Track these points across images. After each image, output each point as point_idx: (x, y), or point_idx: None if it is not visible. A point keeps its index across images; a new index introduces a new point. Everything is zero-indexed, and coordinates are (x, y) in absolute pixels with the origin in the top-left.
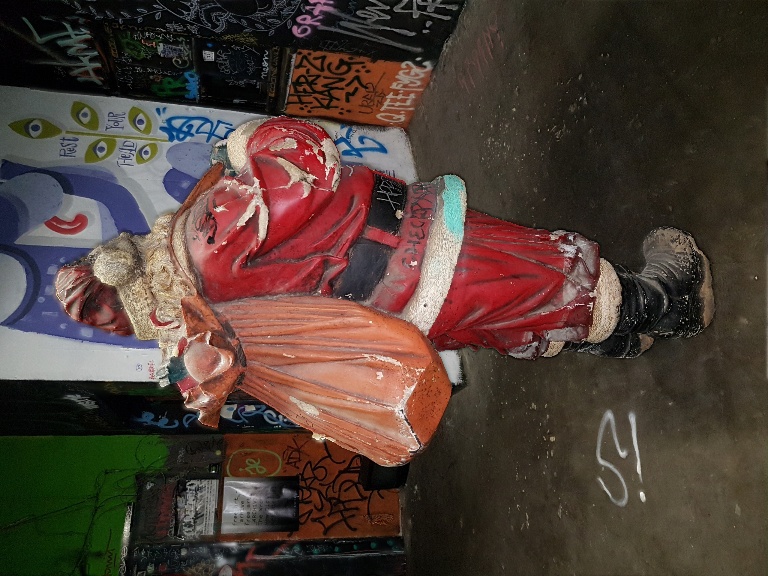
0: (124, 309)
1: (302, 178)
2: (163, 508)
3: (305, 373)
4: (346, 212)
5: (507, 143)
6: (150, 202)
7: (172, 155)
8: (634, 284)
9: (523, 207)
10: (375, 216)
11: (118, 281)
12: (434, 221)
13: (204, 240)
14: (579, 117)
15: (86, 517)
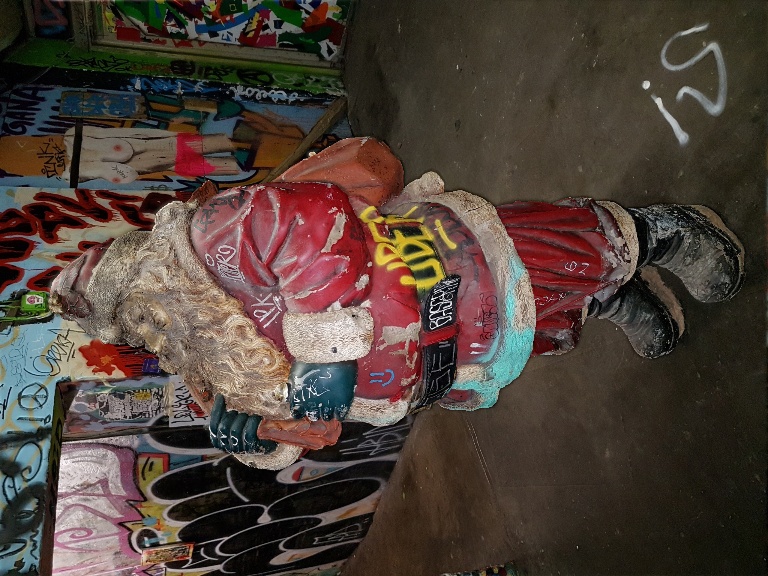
0: None
1: None
2: None
3: None
4: None
5: None
6: None
7: None
8: None
9: None
10: None
11: None
12: None
13: None
14: None
15: None
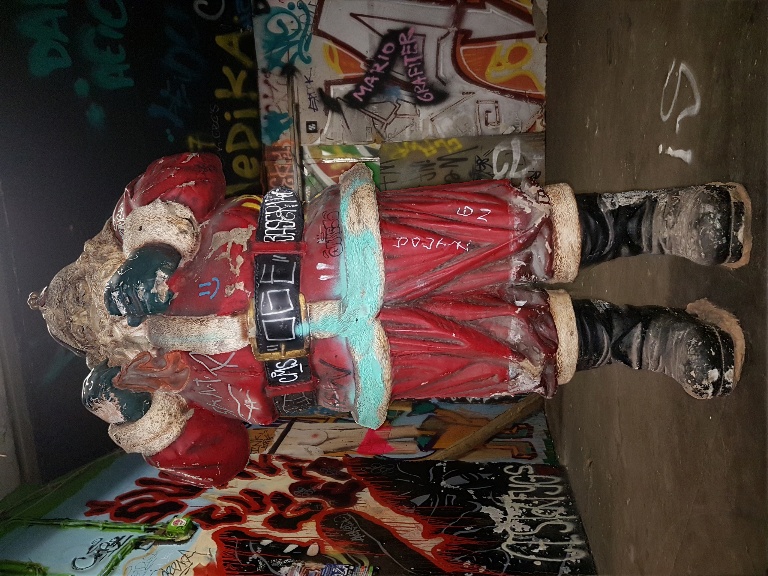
0: None
1: None
2: None
3: None
4: None
5: None
6: None
7: None
8: None
9: None
10: None
11: None
12: None
13: None
14: None
15: None
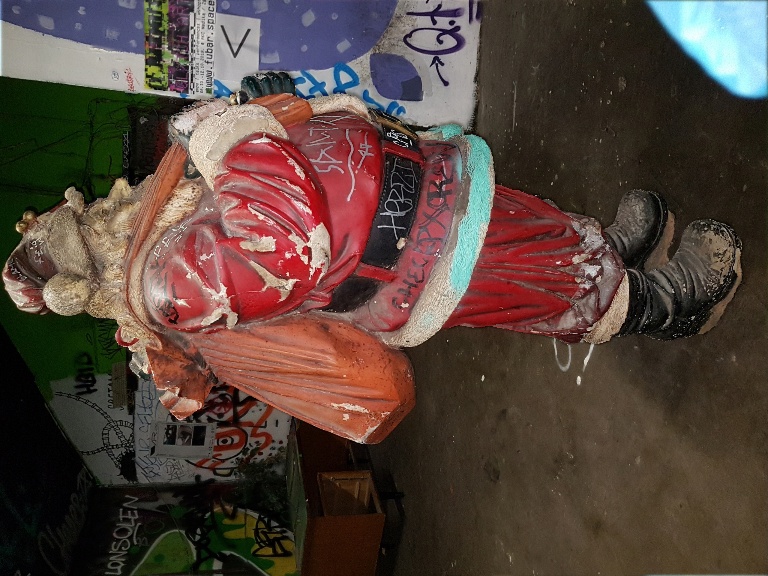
0: None
1: (279, 285)
2: (159, 143)
3: (275, 398)
4: (336, 257)
5: None
6: None
7: None
8: (644, 303)
9: (601, 7)
10: (371, 251)
11: None
12: (440, 262)
13: (165, 318)
14: None
15: (83, 141)
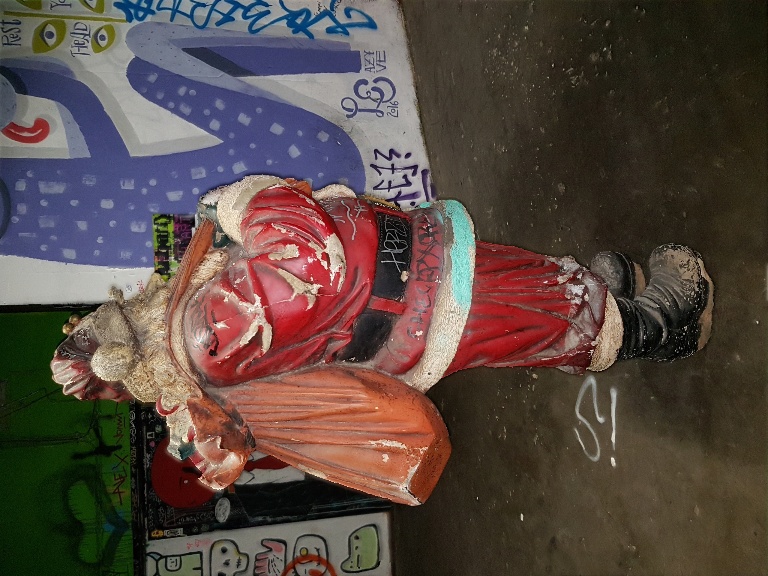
0: (127, 388)
1: (306, 290)
2: None
3: (313, 453)
4: (350, 288)
5: (515, 64)
6: (115, 101)
7: (132, 40)
8: (636, 319)
9: (527, 143)
10: (380, 284)
11: (119, 379)
12: (441, 286)
13: (206, 352)
14: (600, 70)
15: None
